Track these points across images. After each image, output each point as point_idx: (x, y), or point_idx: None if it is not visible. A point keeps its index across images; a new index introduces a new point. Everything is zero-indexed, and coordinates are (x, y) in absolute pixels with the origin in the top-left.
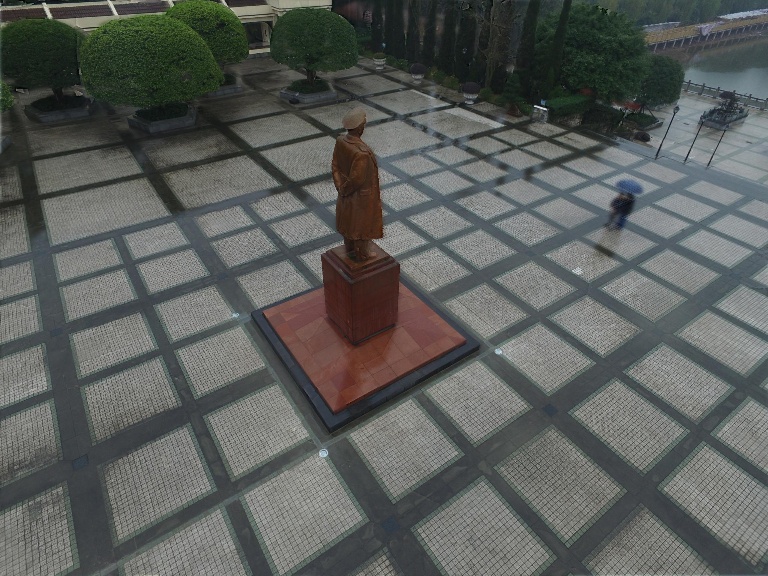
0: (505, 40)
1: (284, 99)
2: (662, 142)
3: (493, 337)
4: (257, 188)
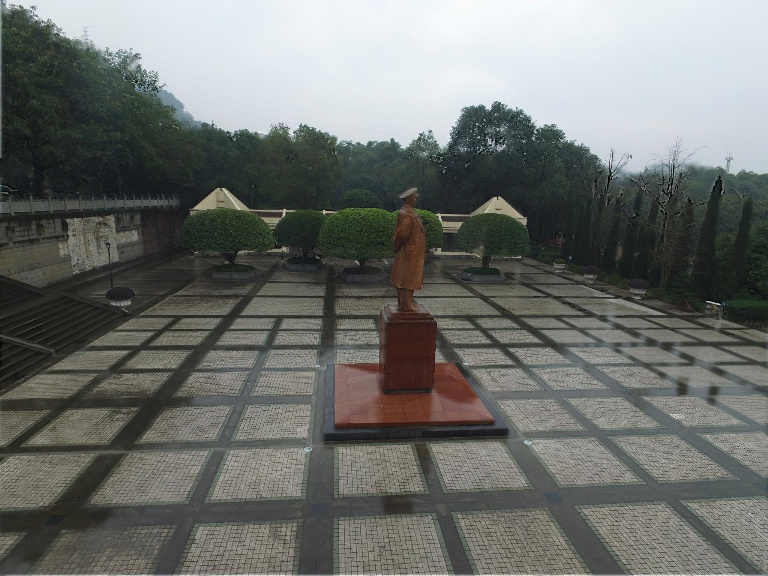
0: (683, 248)
1: (458, 278)
2: None
3: (530, 432)
4: None
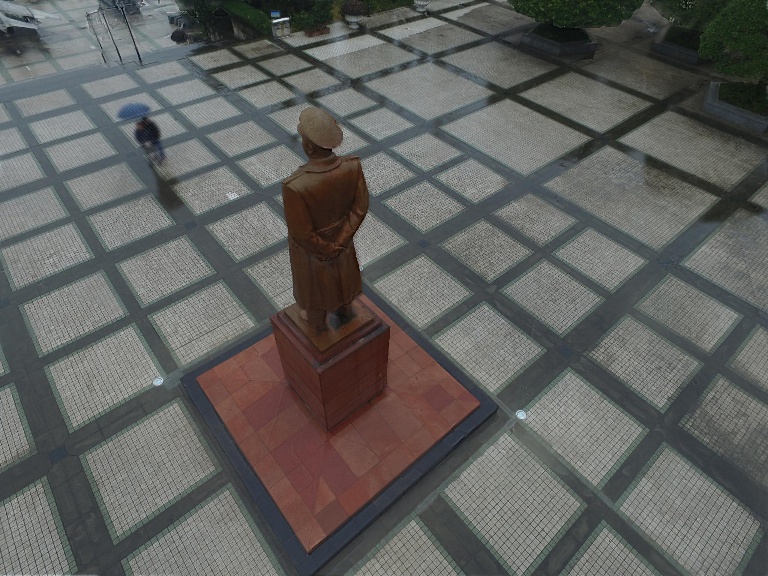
0: None
1: None
2: None
3: None
4: None
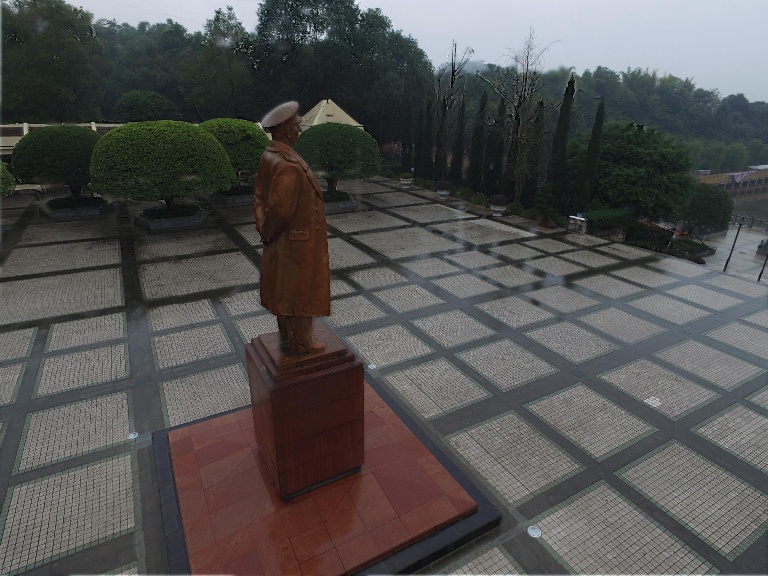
0: (534, 157)
1: None
2: (728, 257)
3: (525, 502)
4: (238, 282)
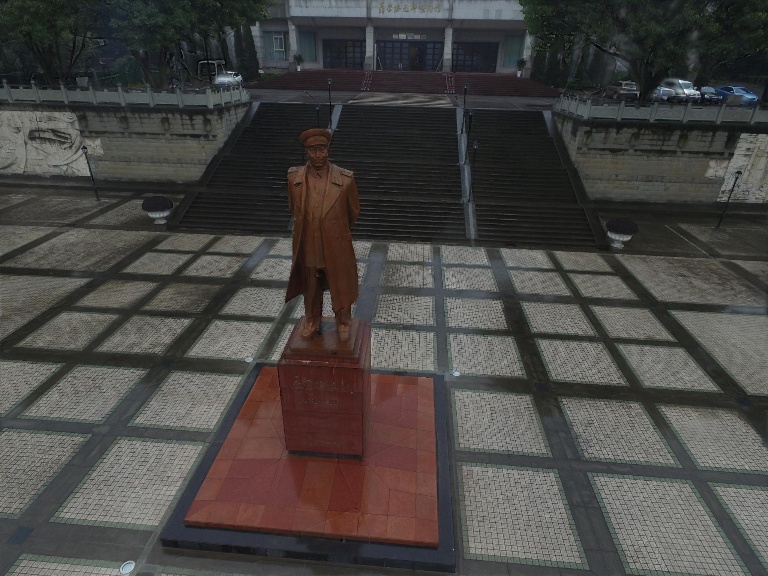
0: None
1: None
2: None
3: None
4: None
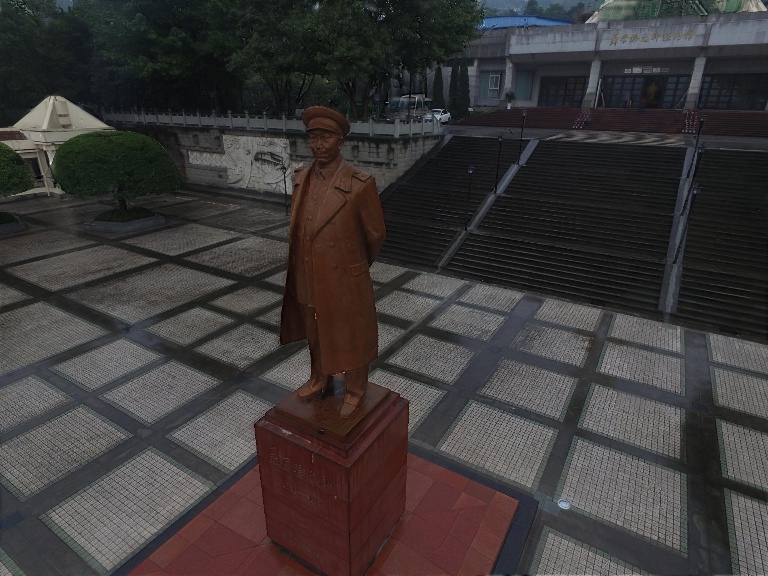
0: None
1: None
2: None
3: None
4: None
